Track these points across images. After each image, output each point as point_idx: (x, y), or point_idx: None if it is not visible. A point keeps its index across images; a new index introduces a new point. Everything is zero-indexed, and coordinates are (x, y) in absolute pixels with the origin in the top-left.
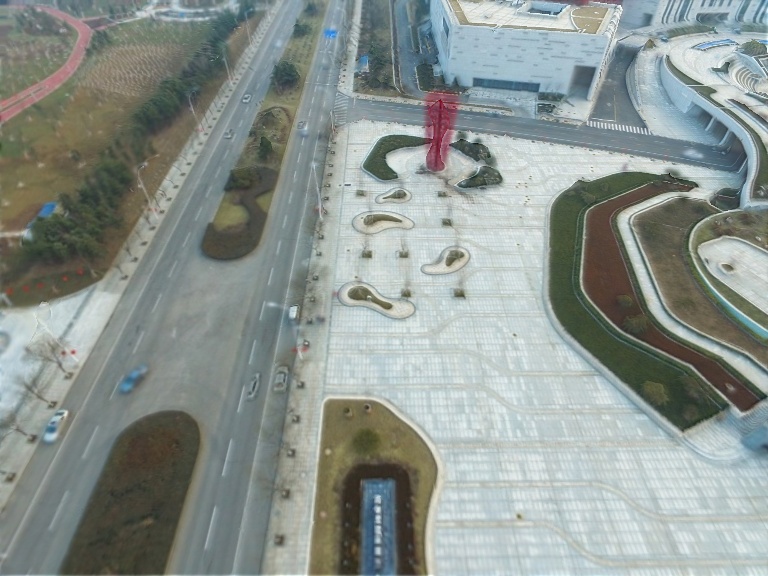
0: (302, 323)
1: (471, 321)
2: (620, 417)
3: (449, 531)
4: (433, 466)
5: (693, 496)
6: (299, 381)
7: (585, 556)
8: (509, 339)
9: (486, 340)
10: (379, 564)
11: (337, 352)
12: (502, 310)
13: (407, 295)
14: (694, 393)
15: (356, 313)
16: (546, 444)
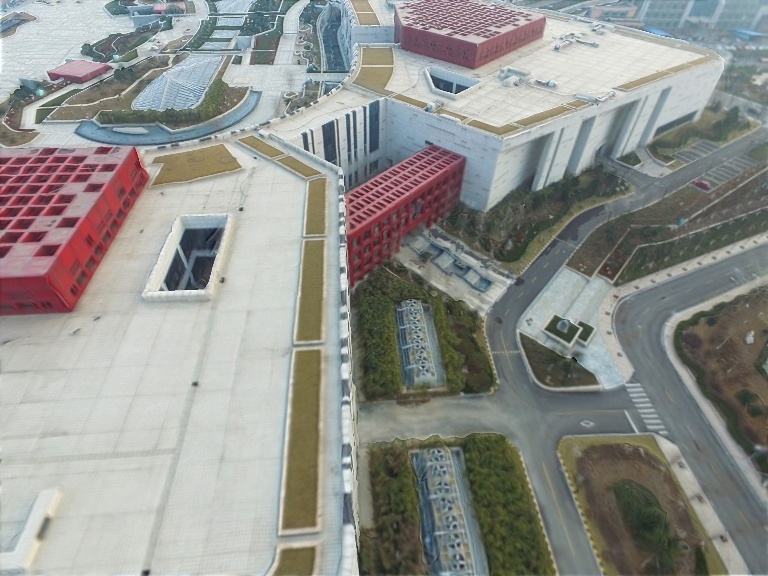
0: (15, 5)
1: (76, 6)
2: (101, 16)
3: (30, 24)
4: (35, 19)
5: (103, 22)
6: (5, 10)
7: (62, 26)
8: (84, 8)
9: (76, 8)
10: (4, 22)
11: (23, 8)
12: (89, 5)
13: (58, 2)
14: (120, 7)
15: (36, 4)
16: (72, 18)
